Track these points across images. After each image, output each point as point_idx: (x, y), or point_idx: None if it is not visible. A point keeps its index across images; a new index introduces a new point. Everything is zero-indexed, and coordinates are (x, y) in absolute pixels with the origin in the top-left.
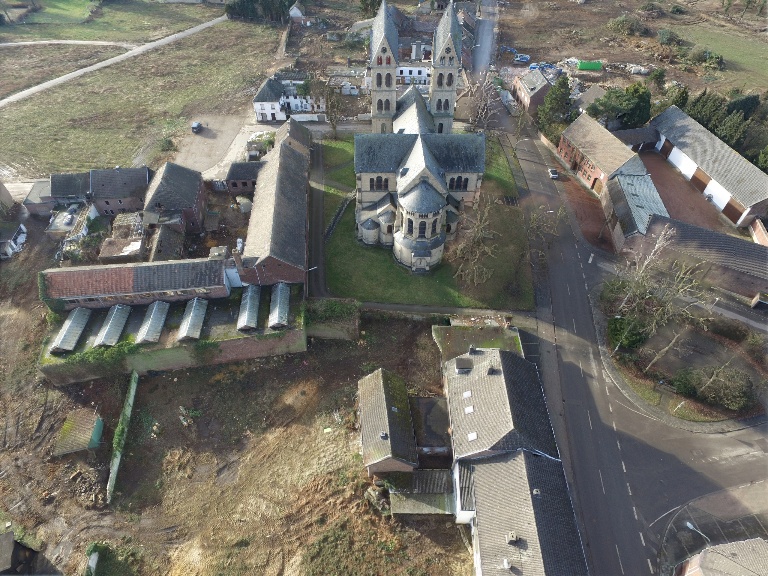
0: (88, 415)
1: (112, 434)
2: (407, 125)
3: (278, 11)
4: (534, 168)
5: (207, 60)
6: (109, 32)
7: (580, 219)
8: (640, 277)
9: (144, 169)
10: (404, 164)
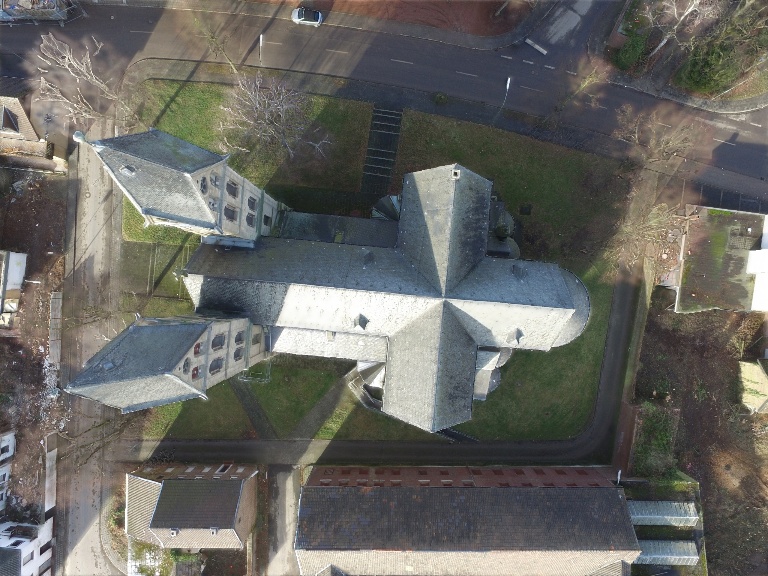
0: None
1: None
2: (356, 310)
3: None
4: (281, 45)
5: None
6: None
7: (443, 24)
8: (703, 18)
9: None
10: (485, 333)
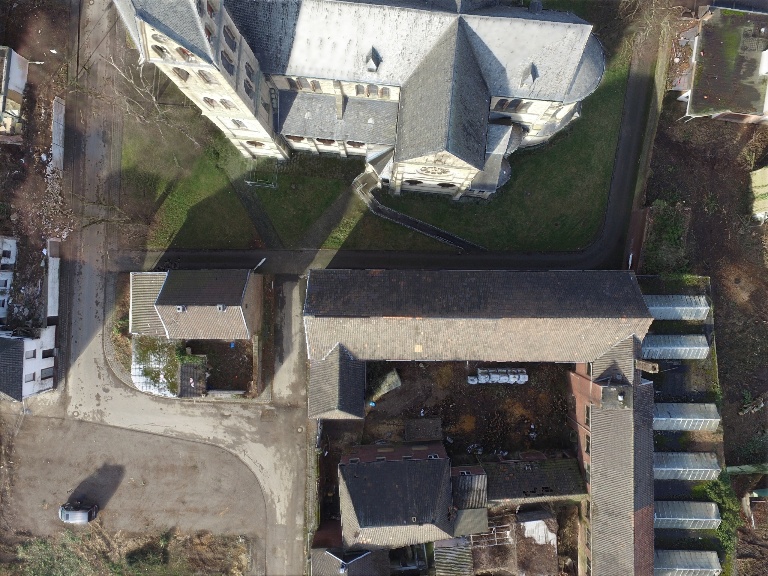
0: (766, 508)
1: (767, 478)
2: (368, 39)
3: None
4: None
5: None
6: None
7: None
8: None
9: (350, 568)
10: (499, 72)
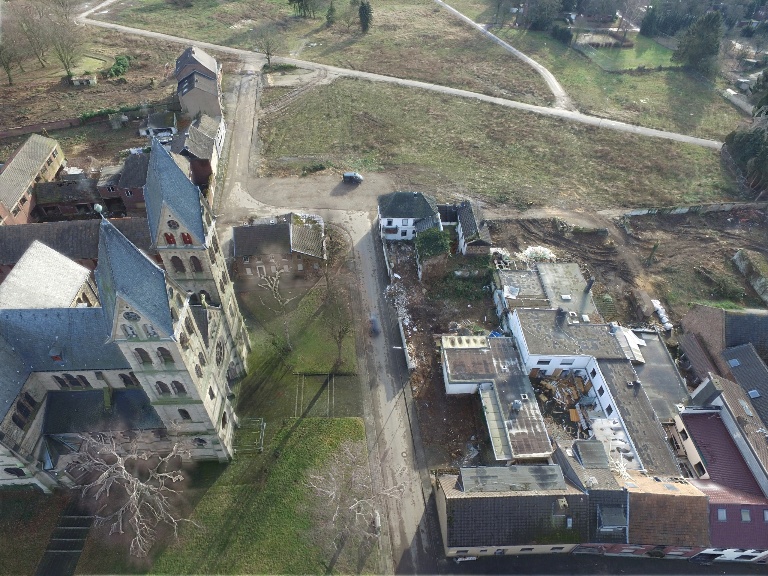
0: None
1: None
2: None
3: (767, 180)
4: None
5: (553, 157)
6: (593, 87)
7: None
8: None
9: None
10: None
